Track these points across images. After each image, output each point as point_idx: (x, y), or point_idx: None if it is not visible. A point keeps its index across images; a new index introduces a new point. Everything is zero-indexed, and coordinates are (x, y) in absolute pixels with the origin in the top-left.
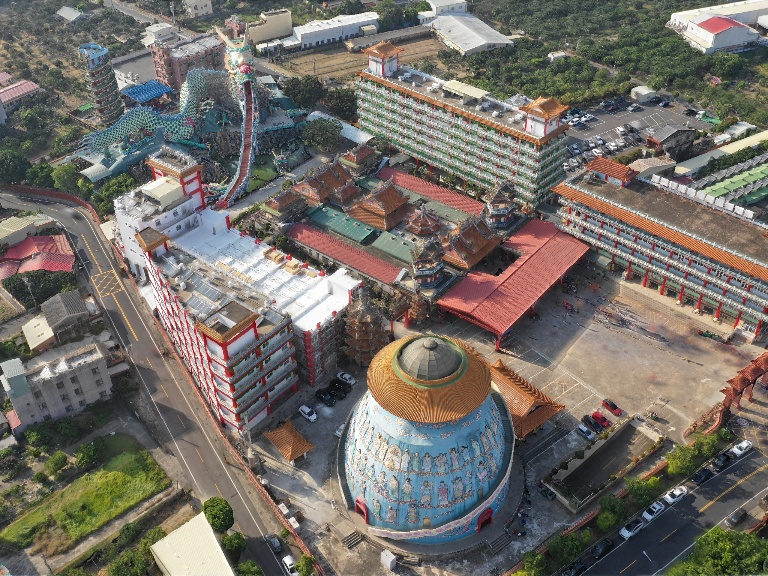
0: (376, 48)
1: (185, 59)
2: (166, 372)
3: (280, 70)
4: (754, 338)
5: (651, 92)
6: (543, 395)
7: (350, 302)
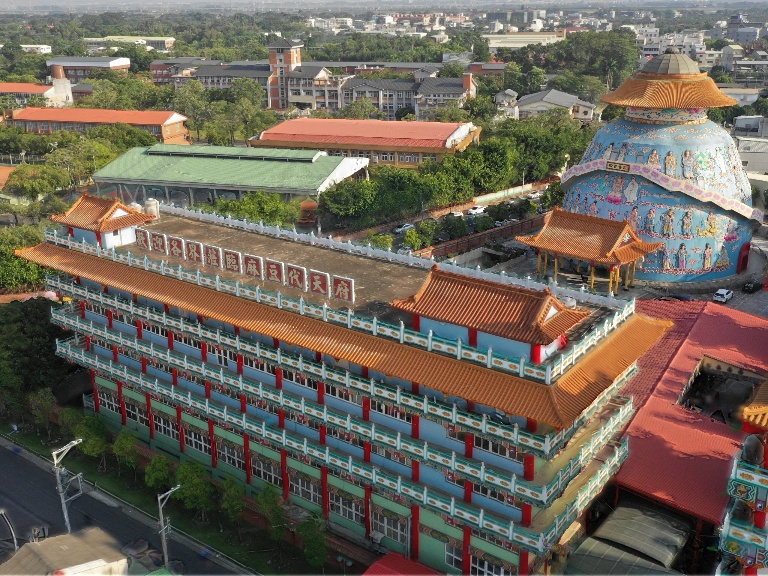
0: None
1: None
2: None
3: None
4: None
5: None
6: (546, 245)
7: None
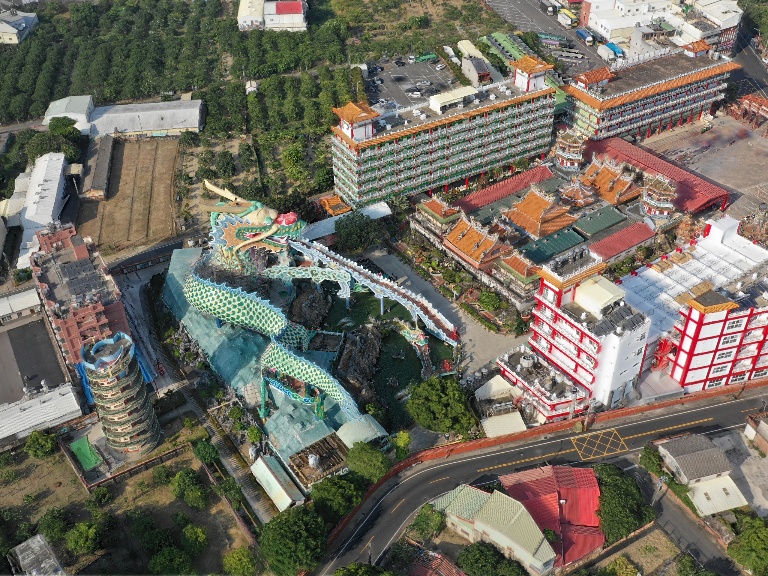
0: (363, 111)
1: (115, 297)
2: (764, 398)
3: (104, 260)
4: (710, 117)
5: (366, 65)
6: None
7: (739, 233)
